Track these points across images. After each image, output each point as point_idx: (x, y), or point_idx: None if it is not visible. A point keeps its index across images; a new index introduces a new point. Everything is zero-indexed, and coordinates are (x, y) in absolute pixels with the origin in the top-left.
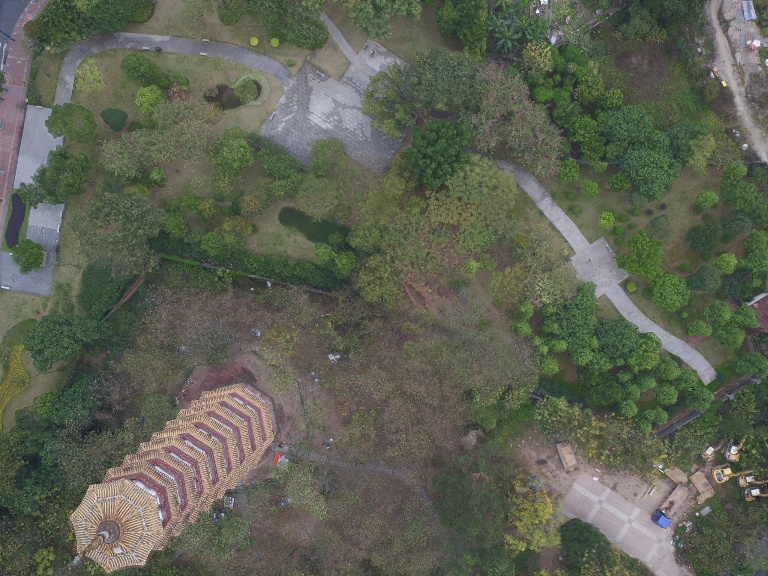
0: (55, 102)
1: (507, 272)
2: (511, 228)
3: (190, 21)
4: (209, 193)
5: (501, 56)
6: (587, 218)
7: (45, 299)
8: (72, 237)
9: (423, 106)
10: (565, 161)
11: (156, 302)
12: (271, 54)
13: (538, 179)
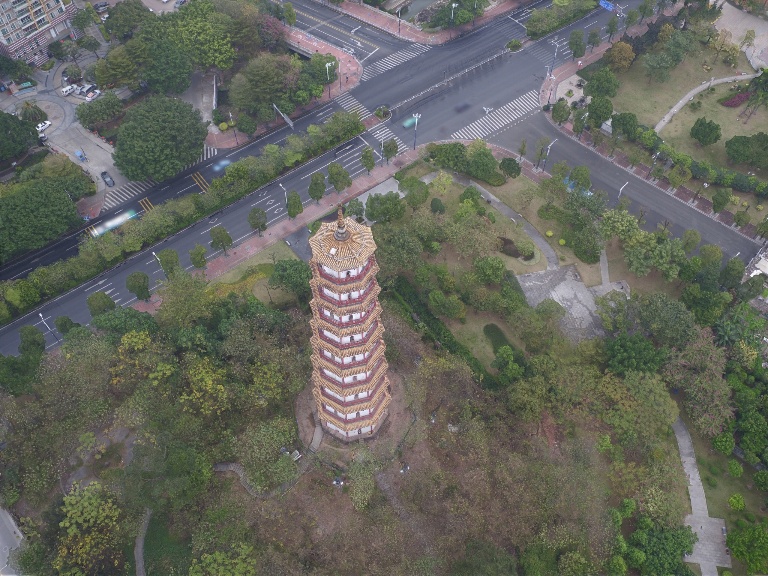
0: None
1: (631, 465)
2: (653, 442)
3: (521, 198)
4: None
5: None
6: (718, 496)
7: None
8: None
9: (640, 324)
10: (725, 433)
11: None
12: (554, 247)
13: (693, 440)
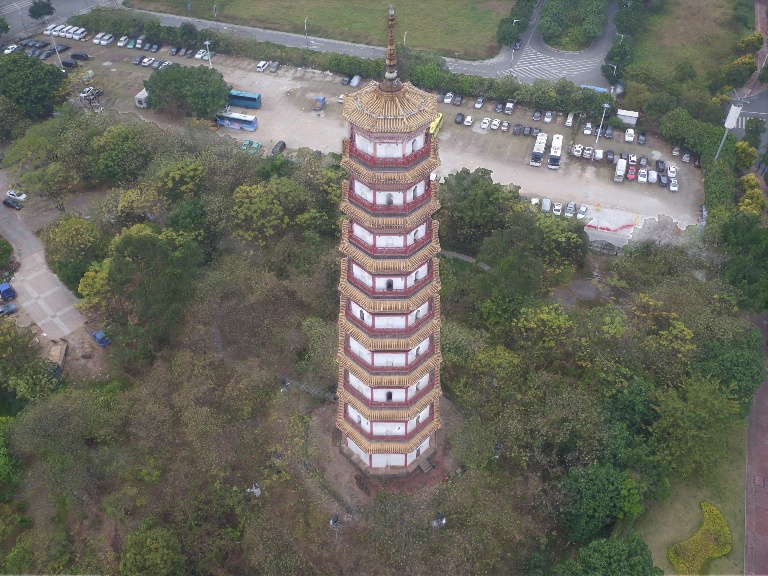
0: None
1: None
2: None
3: None
4: None
5: None
6: None
7: None
8: None
9: None
10: None
11: None
12: None
13: None
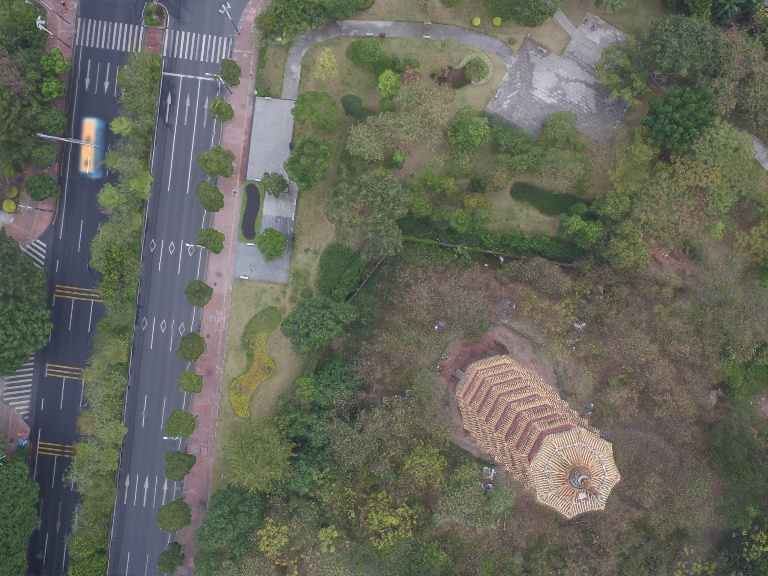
0: (283, 92)
1: (753, 231)
2: (751, 188)
3: (417, 5)
4: (441, 173)
5: (719, 22)
6: None
7: (283, 287)
8: (307, 224)
9: (661, 73)
10: None
11: (411, 281)
12: (492, 33)
13: (762, 140)
